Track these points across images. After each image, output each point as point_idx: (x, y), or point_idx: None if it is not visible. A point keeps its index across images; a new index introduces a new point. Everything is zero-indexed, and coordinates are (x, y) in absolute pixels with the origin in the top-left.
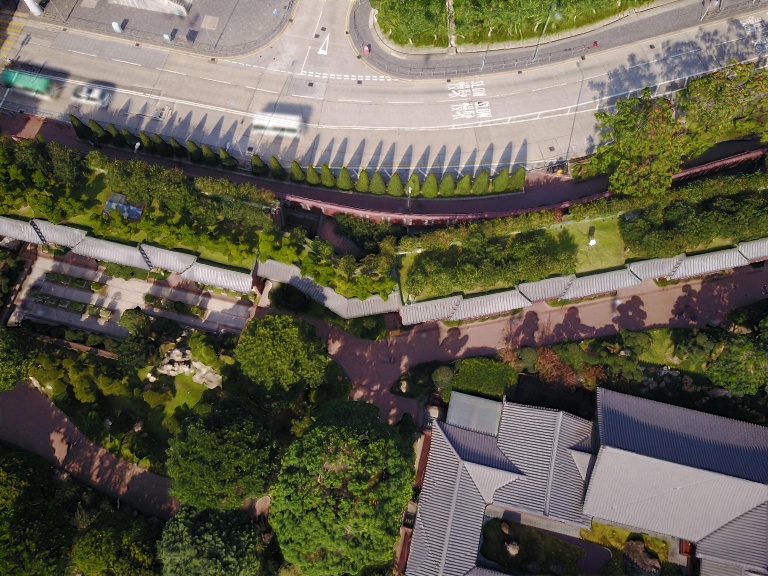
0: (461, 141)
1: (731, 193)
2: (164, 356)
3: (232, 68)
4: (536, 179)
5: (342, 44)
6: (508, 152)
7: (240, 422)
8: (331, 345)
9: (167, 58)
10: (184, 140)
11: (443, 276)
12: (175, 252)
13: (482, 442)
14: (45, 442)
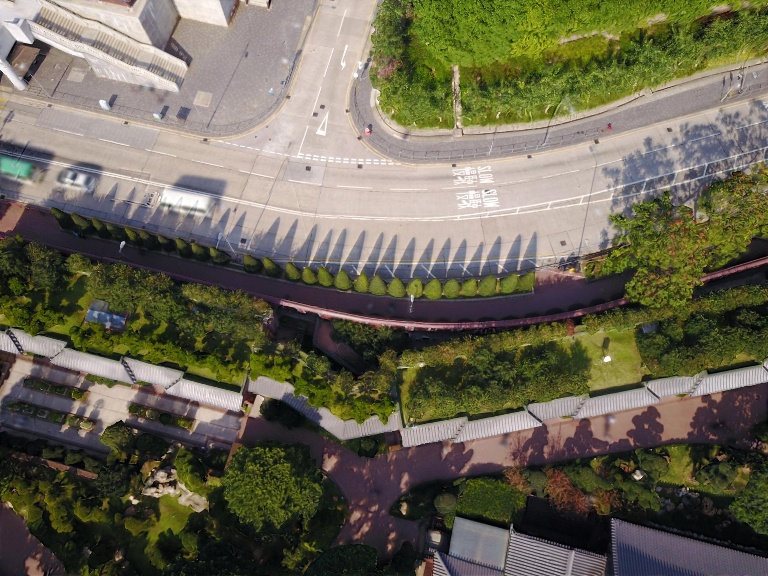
0: (467, 234)
1: (756, 304)
2: (148, 475)
3: (225, 150)
4: (546, 277)
5: (342, 124)
6: (517, 246)
7: (226, 575)
8: (327, 460)
9: (157, 138)
10: (173, 230)
11: (447, 400)
12: (160, 367)
13: None
14: (20, 569)
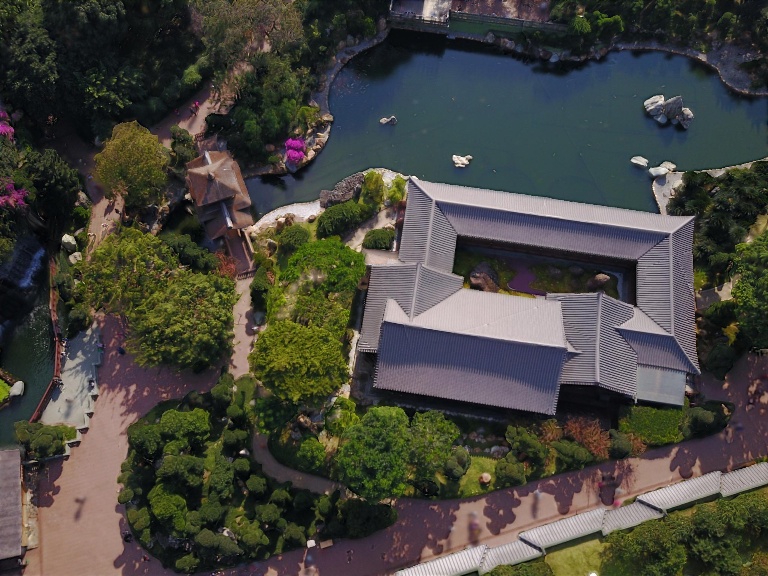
0: None
1: None
2: None
3: None
4: None
5: None
6: None
7: None
8: None
9: None
10: None
11: None
12: None
13: (651, 357)
14: None
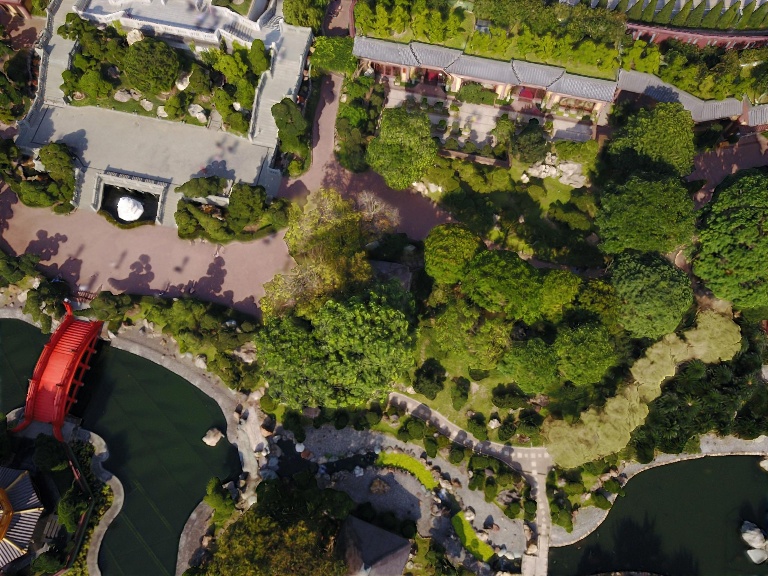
0: None
1: None
2: None
3: None
4: None
5: None
6: None
7: None
8: None
9: None
10: None
11: None
12: (545, 66)
13: None
14: None
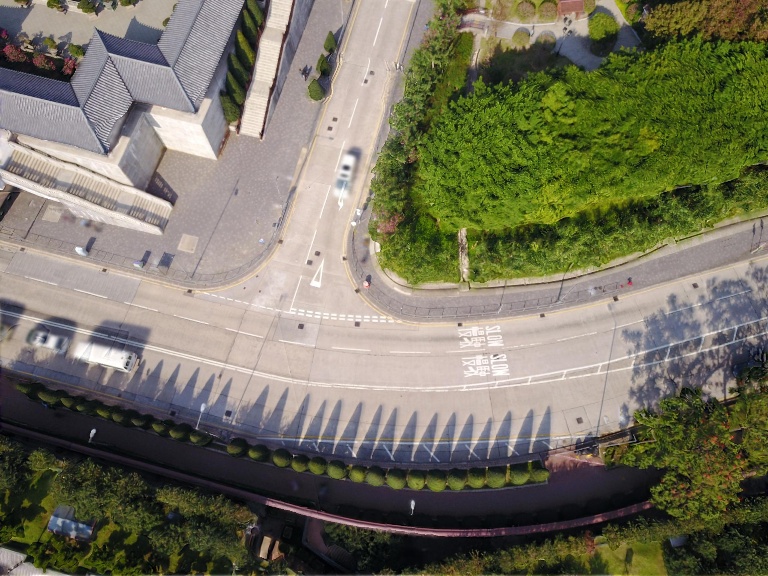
0: (474, 407)
1: None
2: None
3: (211, 303)
4: (561, 462)
5: (338, 273)
6: (528, 424)
7: None
8: None
9: (137, 289)
10: (152, 400)
11: None
12: None
13: None
14: None
